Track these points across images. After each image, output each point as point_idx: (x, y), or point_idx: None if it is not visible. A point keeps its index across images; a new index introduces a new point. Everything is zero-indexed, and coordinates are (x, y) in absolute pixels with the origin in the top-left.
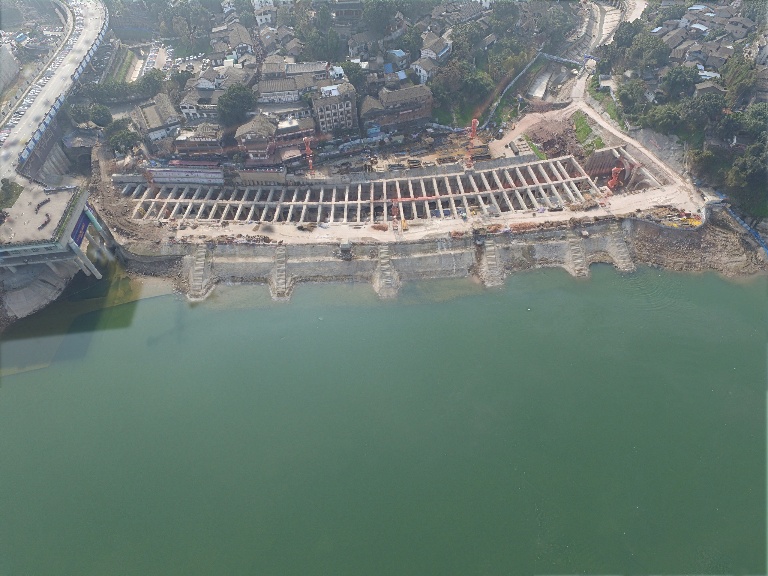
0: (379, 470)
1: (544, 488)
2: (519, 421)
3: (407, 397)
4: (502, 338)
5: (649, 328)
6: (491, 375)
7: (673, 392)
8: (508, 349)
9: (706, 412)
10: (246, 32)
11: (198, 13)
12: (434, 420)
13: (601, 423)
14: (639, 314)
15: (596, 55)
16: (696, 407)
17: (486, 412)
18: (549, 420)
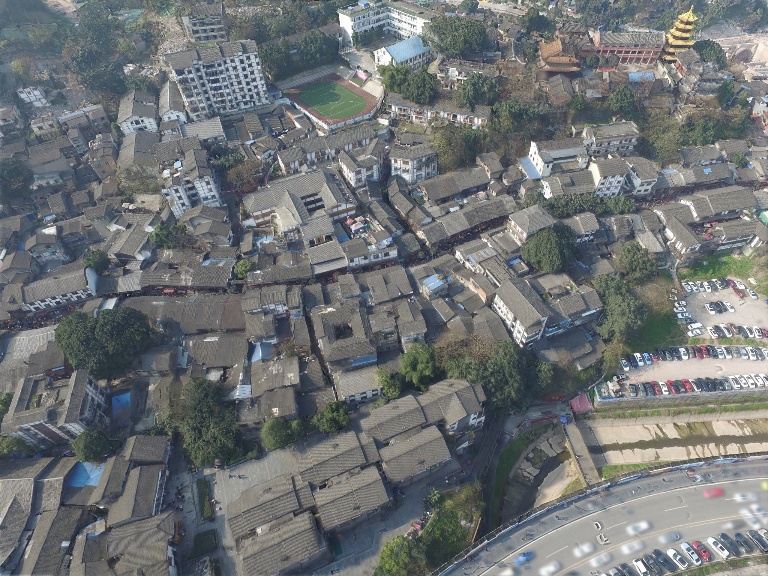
0: None
1: None
2: None
3: None
4: None
5: None
6: None
7: None
8: None
9: None
10: (691, 196)
11: (646, 254)
12: None
13: None
14: None
15: (603, 23)
16: None
17: None
18: None
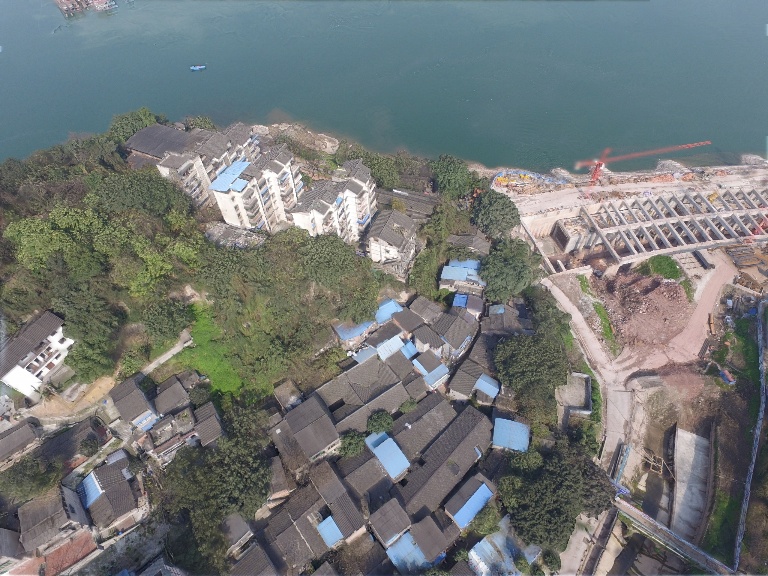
0: (699, 90)
1: (615, 85)
2: (631, 103)
3: (700, 111)
4: (650, 134)
5: (549, 138)
6: (653, 117)
7: (543, 111)
8: (644, 131)
9: (528, 104)
10: None
11: None
12: (679, 103)
13: (586, 102)
14: (553, 147)
15: None
16: (532, 106)
17: (651, 105)
18: (614, 105)
